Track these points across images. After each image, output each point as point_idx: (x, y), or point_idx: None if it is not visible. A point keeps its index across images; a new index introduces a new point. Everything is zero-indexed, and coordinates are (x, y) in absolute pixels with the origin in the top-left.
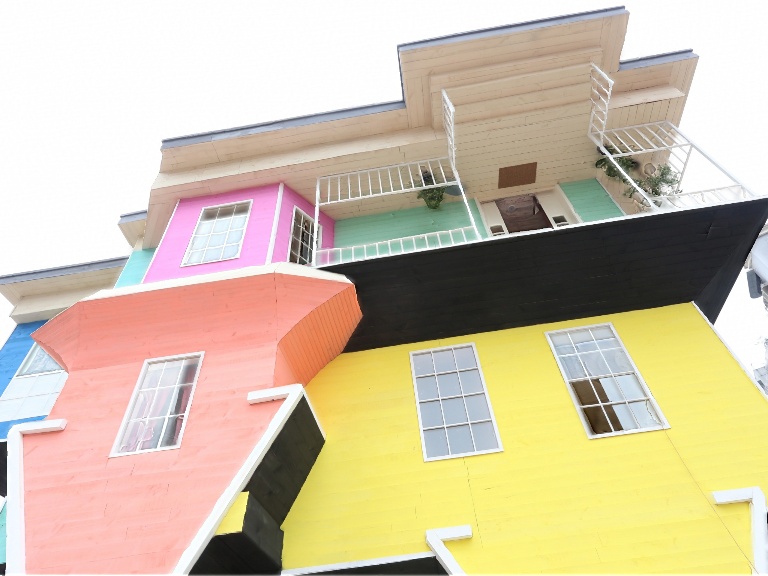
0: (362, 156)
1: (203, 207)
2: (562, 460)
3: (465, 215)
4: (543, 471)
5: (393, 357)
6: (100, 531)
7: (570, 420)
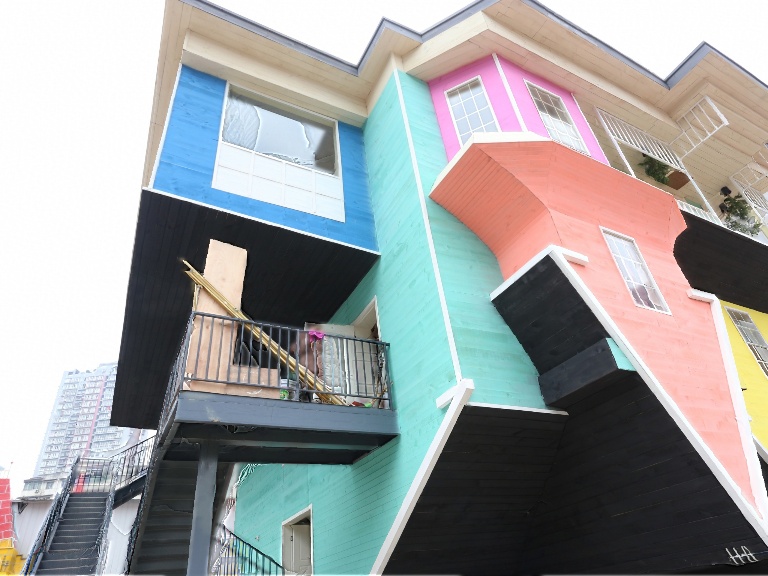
0: (634, 110)
1: None
2: (763, 389)
3: None
4: (759, 393)
5: None
6: (673, 364)
7: (757, 367)
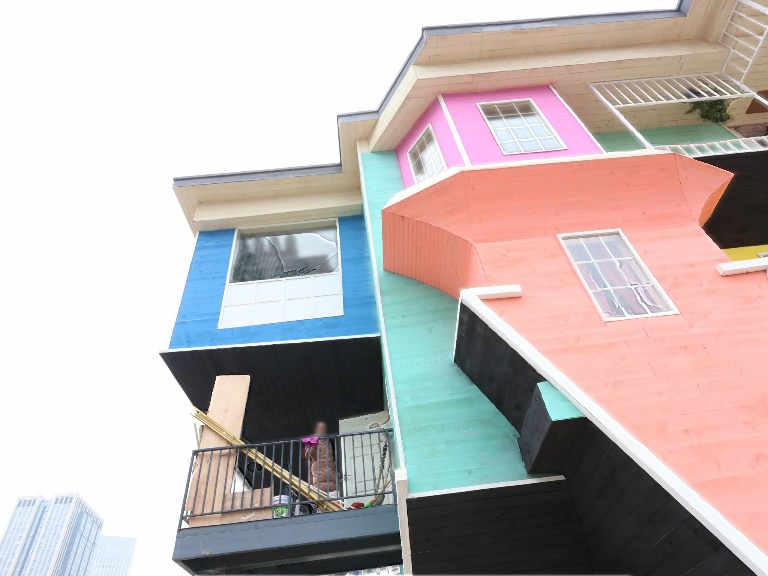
0: (642, 62)
1: (477, 103)
2: None
3: (721, 136)
4: None
5: (743, 258)
6: (665, 387)
7: None
